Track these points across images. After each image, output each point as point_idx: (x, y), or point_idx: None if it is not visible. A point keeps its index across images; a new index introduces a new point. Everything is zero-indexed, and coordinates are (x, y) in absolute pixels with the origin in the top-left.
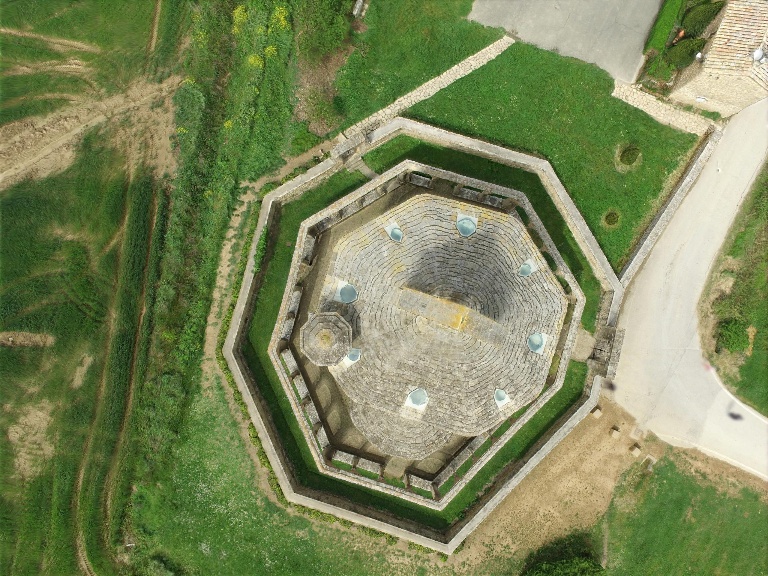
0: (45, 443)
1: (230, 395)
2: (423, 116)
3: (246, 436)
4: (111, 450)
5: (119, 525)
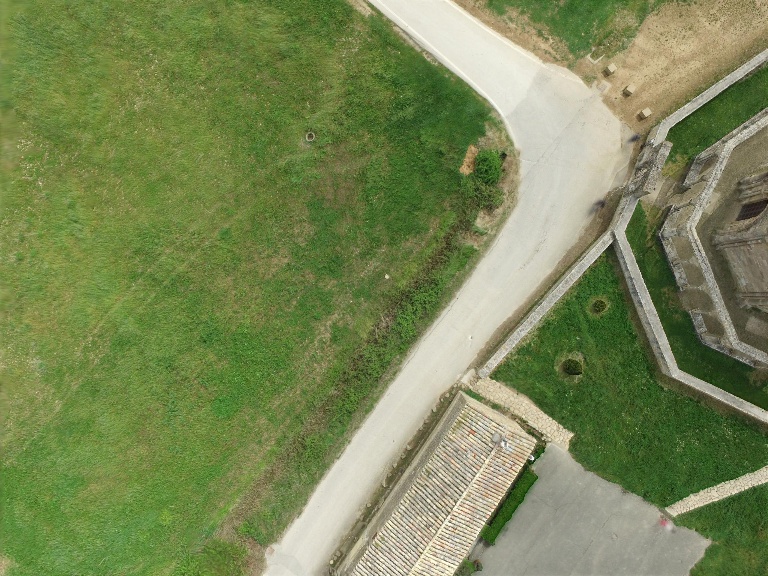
0: None
1: None
2: None
3: None
4: None
5: None
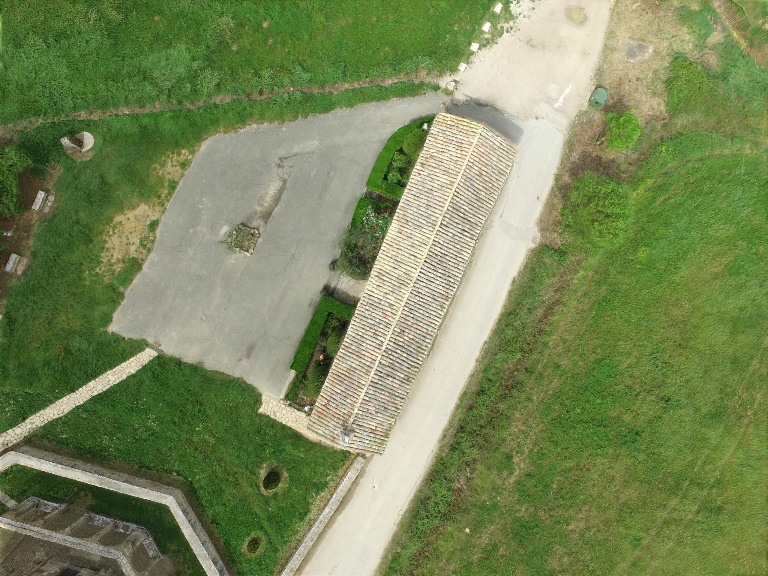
0: None
1: None
2: (55, 436)
3: None
4: None
5: None
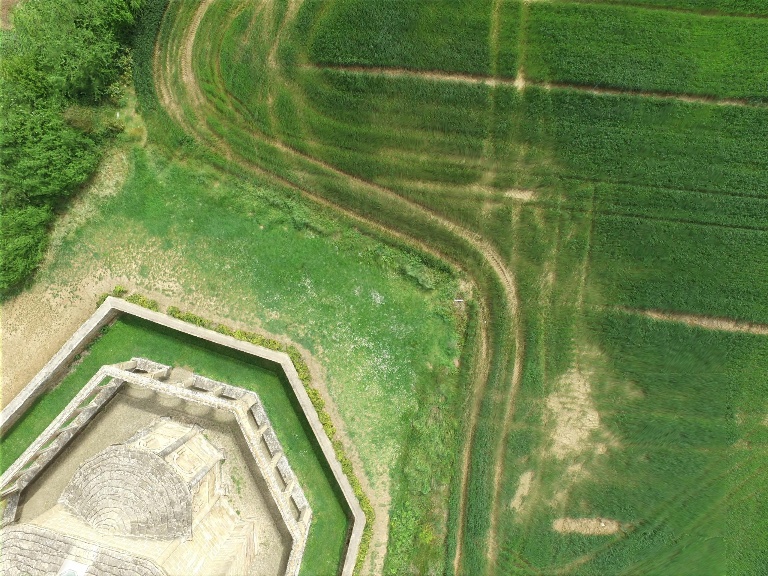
0: (558, 410)
1: (358, 466)
2: None
3: (338, 421)
4: (483, 407)
5: (470, 325)
